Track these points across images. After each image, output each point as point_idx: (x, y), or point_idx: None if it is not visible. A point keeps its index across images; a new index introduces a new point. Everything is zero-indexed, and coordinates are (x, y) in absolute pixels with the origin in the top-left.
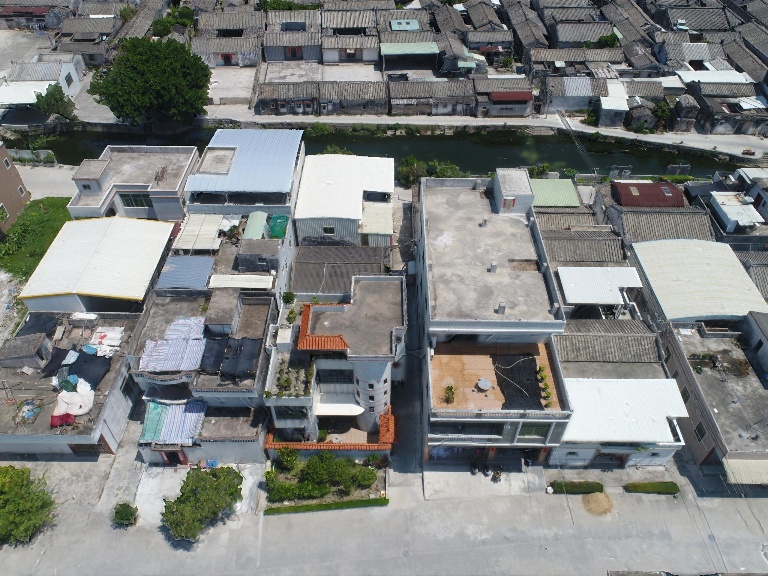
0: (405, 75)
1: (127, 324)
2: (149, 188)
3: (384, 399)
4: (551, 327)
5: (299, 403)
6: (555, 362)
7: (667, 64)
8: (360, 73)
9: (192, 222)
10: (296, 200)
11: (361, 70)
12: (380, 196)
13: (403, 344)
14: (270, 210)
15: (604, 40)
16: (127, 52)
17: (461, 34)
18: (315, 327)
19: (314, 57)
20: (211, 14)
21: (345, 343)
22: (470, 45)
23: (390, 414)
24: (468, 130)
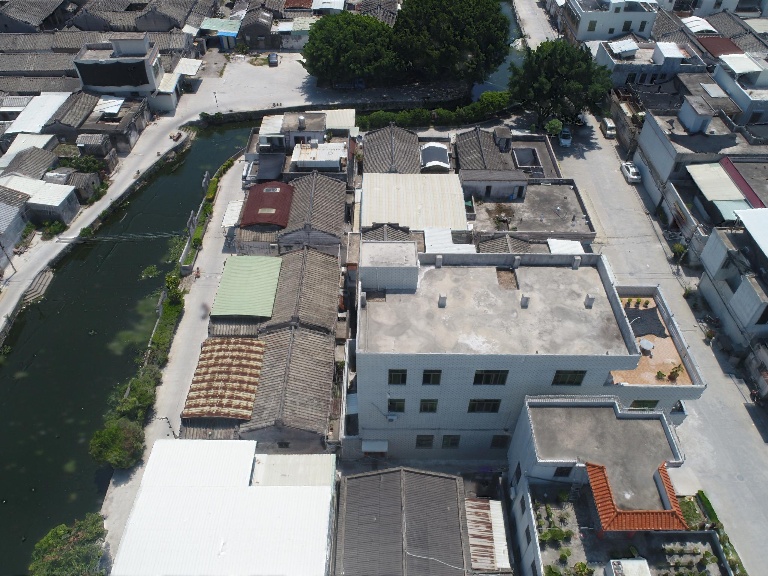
0: None
1: None
2: None
3: None
4: None
5: None
6: None
7: None
8: None
9: None
10: None
11: None
12: None
13: None
14: None
15: None
16: None
17: None
18: None
19: None
20: None
21: None
22: None
23: None
24: None
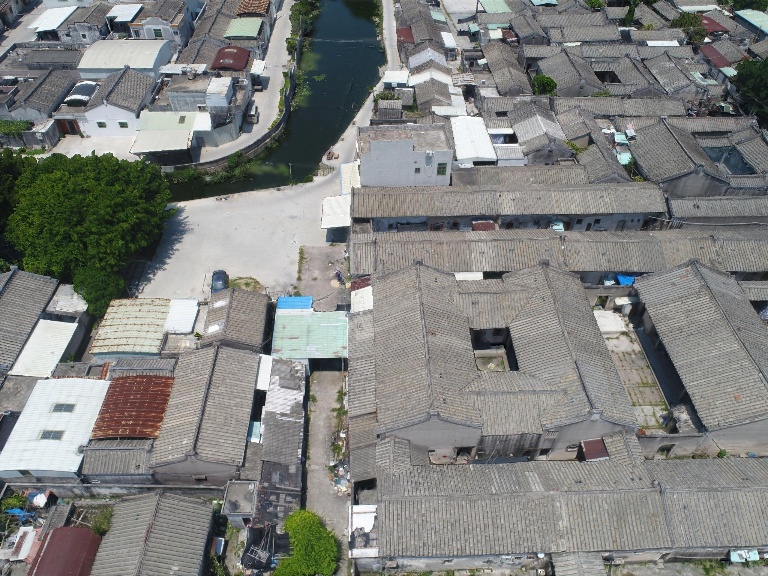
0: None
1: None
2: None
3: None
4: None
5: None
6: None
7: None
8: (469, 5)
9: None
10: None
11: (475, 6)
12: None
13: None
14: None
15: None
16: None
17: None
18: None
19: None
20: None
21: None
22: None
23: None
24: (381, 43)
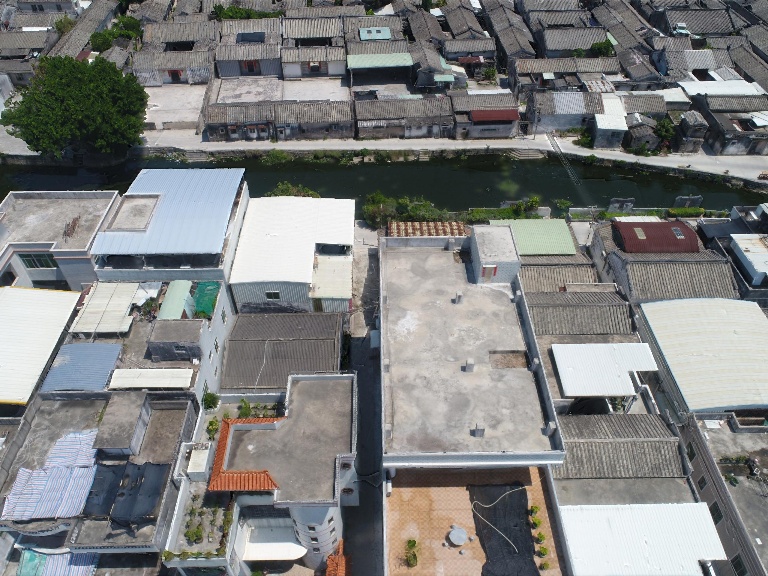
0: (374, 92)
1: (11, 432)
2: (52, 248)
3: (332, 537)
4: (546, 458)
5: (212, 564)
6: (552, 497)
7: (668, 74)
8: (325, 89)
9: (99, 294)
10: (233, 258)
11: (326, 86)
12: (338, 246)
13: (353, 470)
14: (198, 274)
15: (597, 48)
16: (46, 74)
17: (438, 43)
18: (235, 454)
19: (274, 72)
20: (158, 25)
21: (272, 481)
22: (448, 55)
23: (341, 554)
24: (446, 155)
